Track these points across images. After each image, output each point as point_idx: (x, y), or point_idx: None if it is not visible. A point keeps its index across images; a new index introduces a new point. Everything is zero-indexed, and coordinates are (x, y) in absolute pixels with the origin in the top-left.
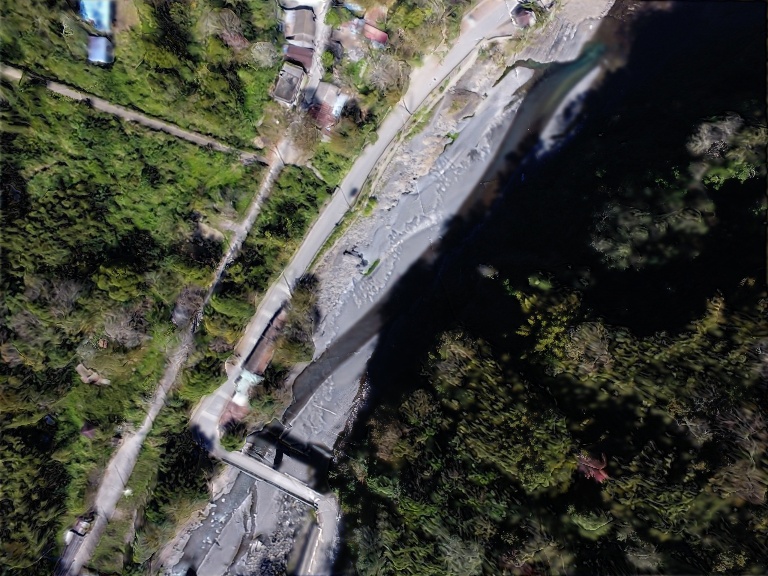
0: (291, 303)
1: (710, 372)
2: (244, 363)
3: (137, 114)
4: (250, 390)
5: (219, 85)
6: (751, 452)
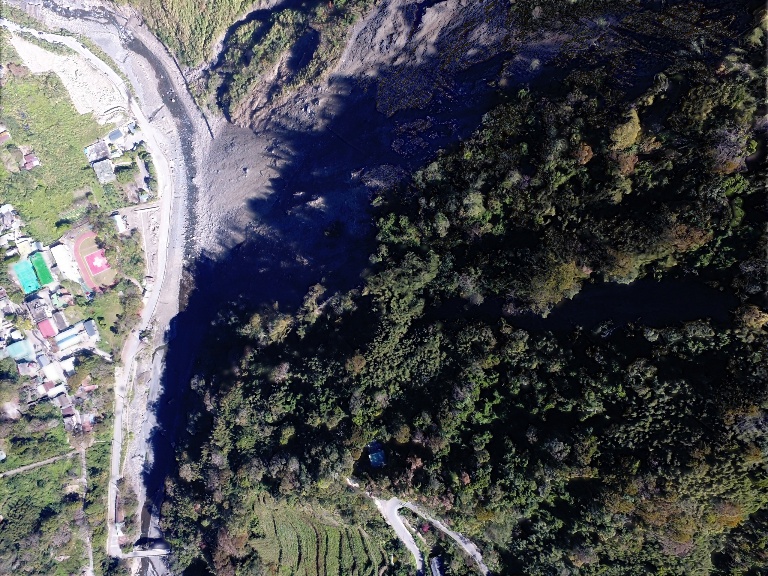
0: (119, 491)
1: (211, 467)
2: (115, 521)
3: (24, 467)
4: (121, 530)
5: None
6: (220, 488)
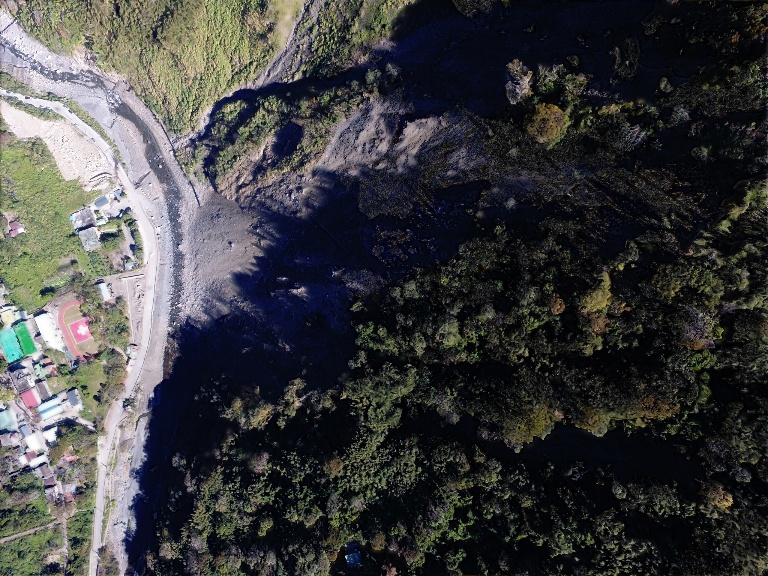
0: (100, 559)
1: None
2: None
3: (5, 539)
4: None
5: (25, 518)
6: (199, 573)
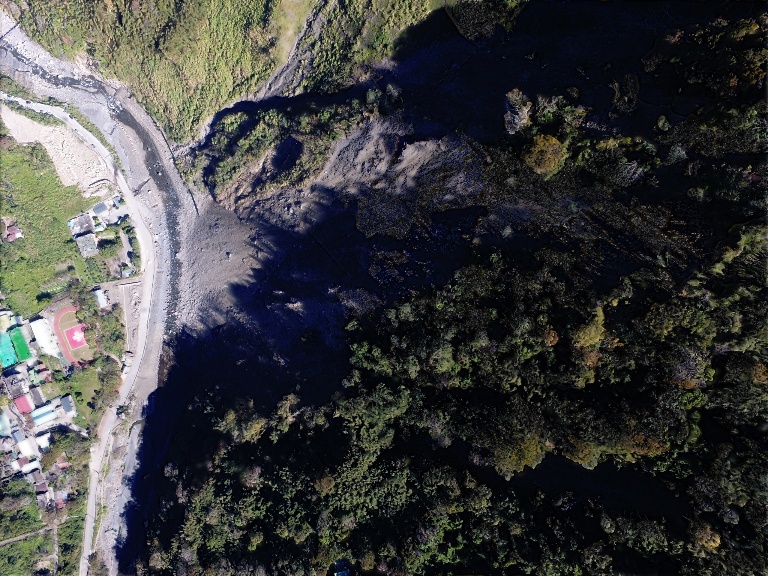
0: None
1: None
2: None
3: None
4: None
5: (15, 524)
6: None
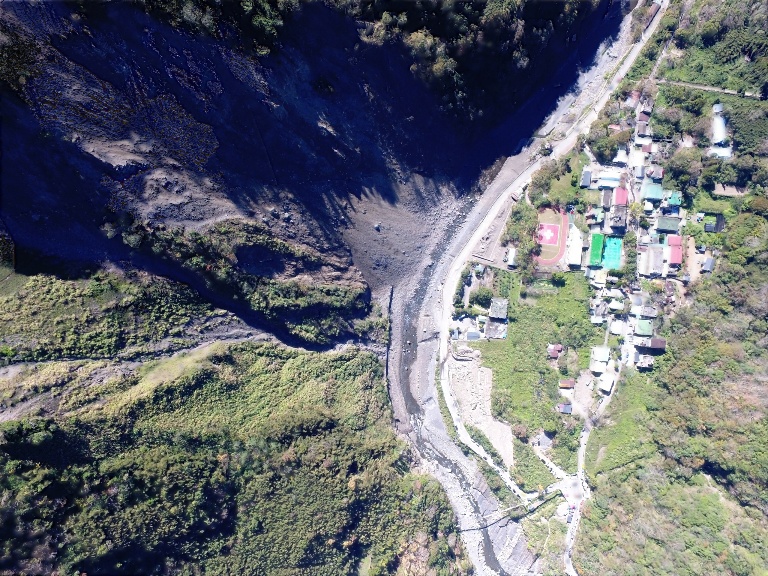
0: None
1: None
2: (660, 8)
3: (705, 88)
4: None
5: None
6: None
